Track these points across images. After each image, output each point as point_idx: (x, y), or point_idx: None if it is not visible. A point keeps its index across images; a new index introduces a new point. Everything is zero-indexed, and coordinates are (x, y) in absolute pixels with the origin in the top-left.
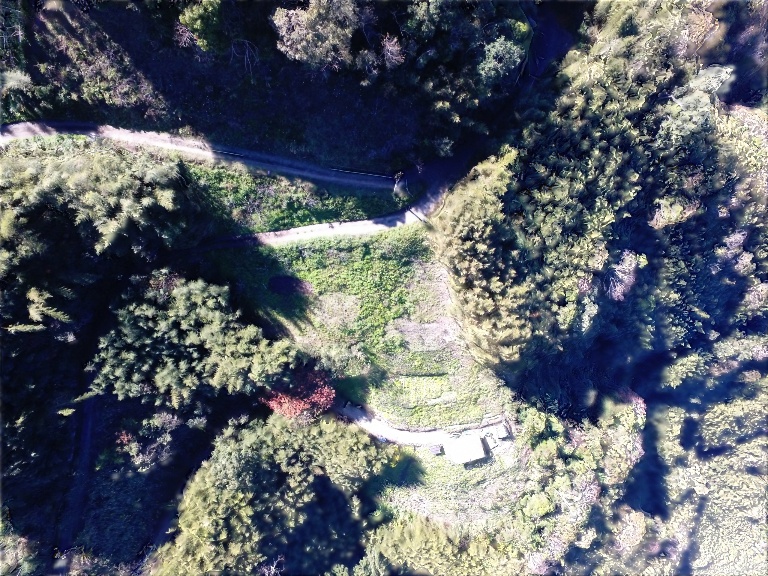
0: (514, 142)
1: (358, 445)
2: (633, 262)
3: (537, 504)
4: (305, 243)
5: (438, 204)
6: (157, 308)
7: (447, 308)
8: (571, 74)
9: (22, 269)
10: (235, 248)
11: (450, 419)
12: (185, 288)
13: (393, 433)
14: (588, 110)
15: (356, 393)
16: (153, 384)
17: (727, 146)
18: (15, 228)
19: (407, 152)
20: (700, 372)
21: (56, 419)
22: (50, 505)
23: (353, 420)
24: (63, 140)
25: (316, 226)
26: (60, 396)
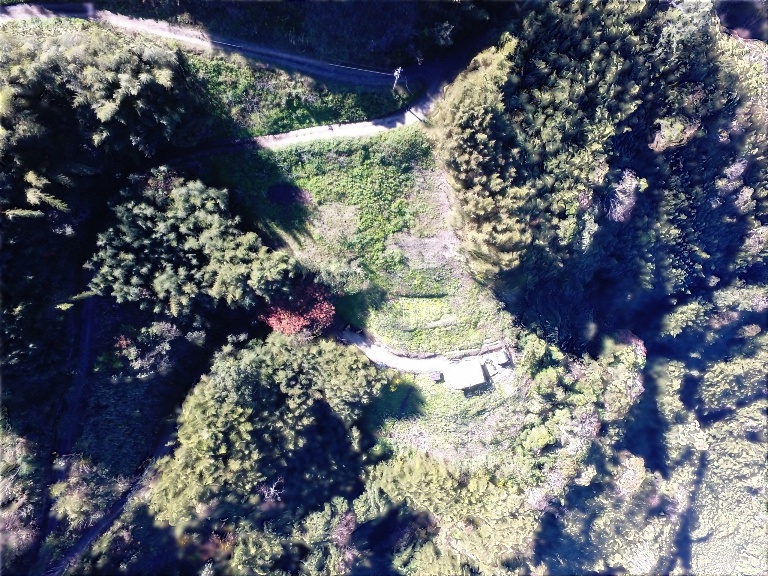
0: (514, 31)
1: (358, 364)
2: (633, 182)
3: (537, 435)
4: (304, 145)
5: (438, 104)
6: (156, 208)
7: (447, 221)
8: None
9: (20, 150)
10: (234, 152)
11: (450, 344)
12: (184, 188)
13: (393, 359)
14: (589, 6)
15: (356, 315)
16: (152, 288)
17: (728, 62)
18: (12, 105)
19: (407, 43)
20: (700, 322)
21: (54, 314)
22: (48, 406)
23: (353, 343)
24: (61, 22)
25: (315, 128)
26: (58, 293)
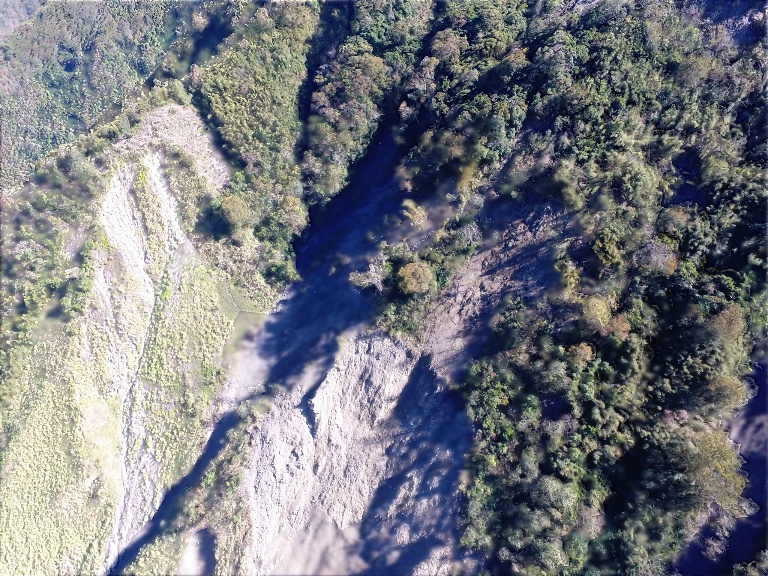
0: None
1: None
2: None
3: None
4: None
5: None
6: None
7: None
8: None
9: None
10: None
11: None
12: None
13: None
14: None
15: None
16: None
17: None
18: None
19: None
20: None
21: None
22: None
23: None
24: None
25: None
26: None
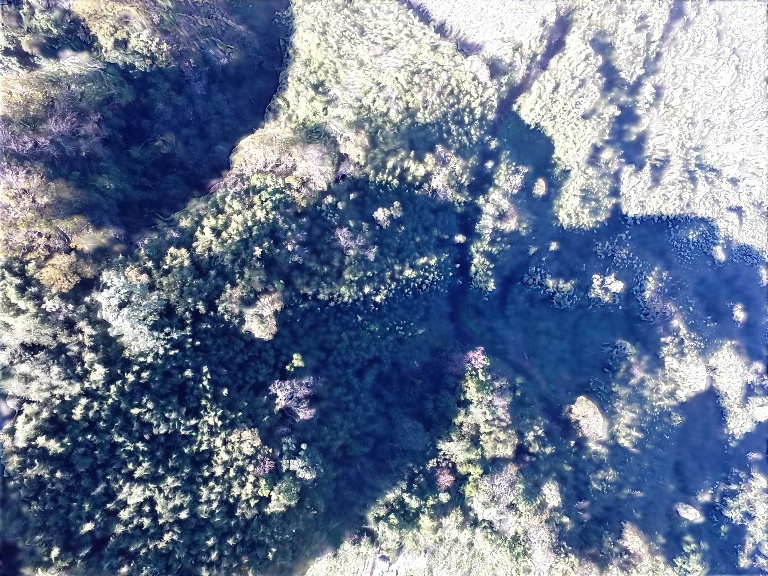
0: (36, 564)
1: None
2: (286, 386)
3: None
4: None
5: None
6: None
7: None
8: (6, 473)
9: None
10: None
11: None
12: None
13: None
14: (61, 453)
15: None
16: None
17: (219, 256)
18: None
19: None
20: (498, 251)
21: None
22: None
23: None
24: None
25: None
26: None
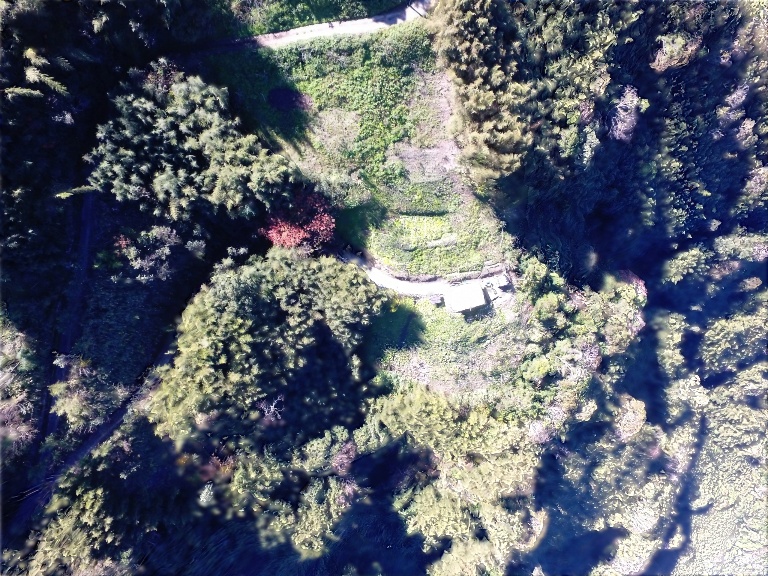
0: None
1: (358, 279)
2: (635, 99)
3: (538, 364)
4: (305, 43)
5: None
6: (155, 104)
7: (448, 130)
8: None
9: (19, 26)
10: (234, 51)
11: (450, 265)
12: (184, 83)
13: (393, 282)
14: None
15: (356, 234)
16: (152, 188)
17: None
18: None
19: None
20: (701, 271)
21: (54, 204)
22: (48, 301)
23: (353, 263)
24: None
25: (316, 26)
26: (58, 184)
